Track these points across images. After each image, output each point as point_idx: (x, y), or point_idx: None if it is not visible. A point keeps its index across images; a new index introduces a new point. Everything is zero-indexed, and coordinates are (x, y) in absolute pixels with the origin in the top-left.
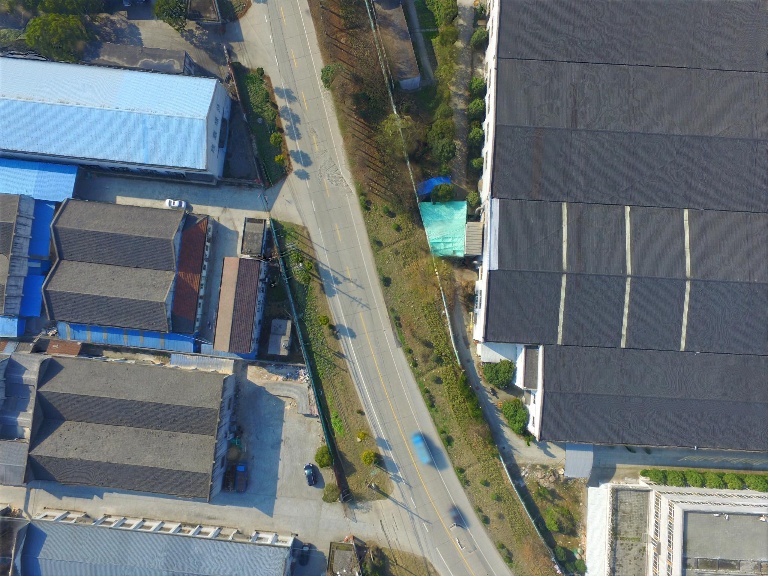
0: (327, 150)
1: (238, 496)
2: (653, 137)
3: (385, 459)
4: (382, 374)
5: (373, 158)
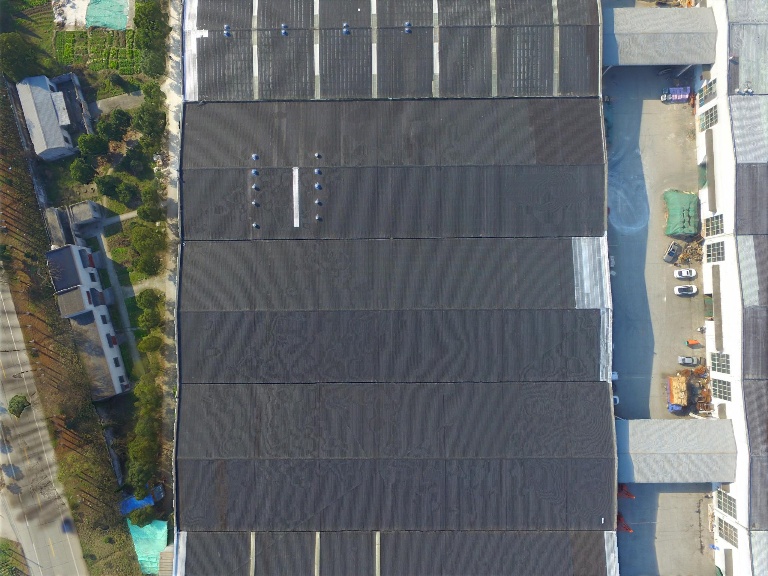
0: (38, 462)
1: None
2: (337, 462)
3: None
4: None
5: None
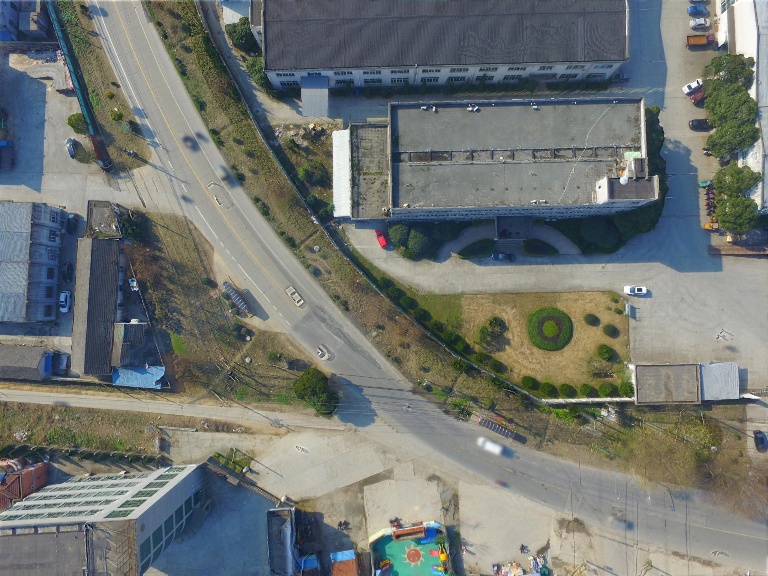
0: None
1: (7, 175)
2: None
3: (142, 127)
4: (135, 48)
5: None
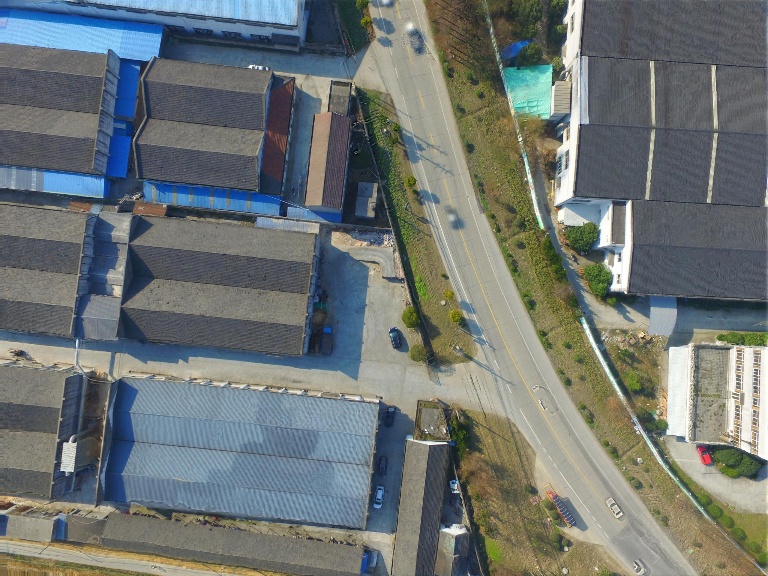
0: (410, 18)
1: (323, 360)
2: None
3: (469, 322)
4: (466, 239)
5: (456, 26)
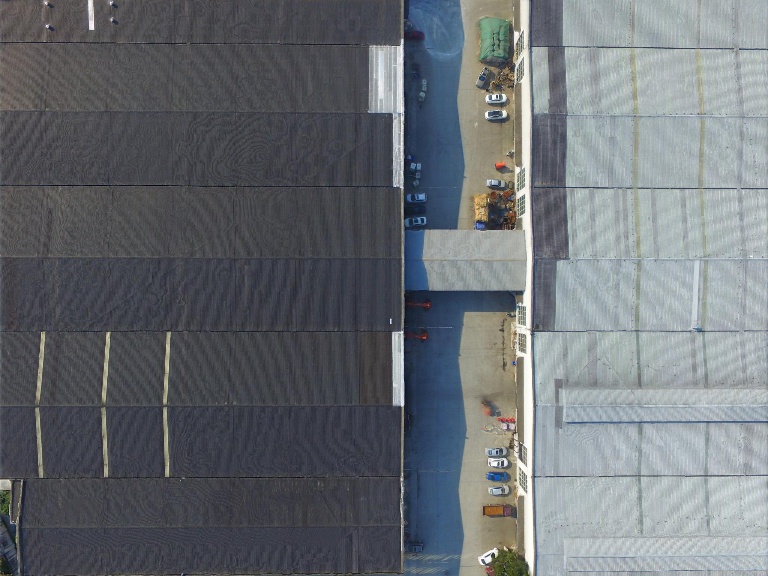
0: None
1: None
2: (127, 261)
3: None
4: None
5: None
